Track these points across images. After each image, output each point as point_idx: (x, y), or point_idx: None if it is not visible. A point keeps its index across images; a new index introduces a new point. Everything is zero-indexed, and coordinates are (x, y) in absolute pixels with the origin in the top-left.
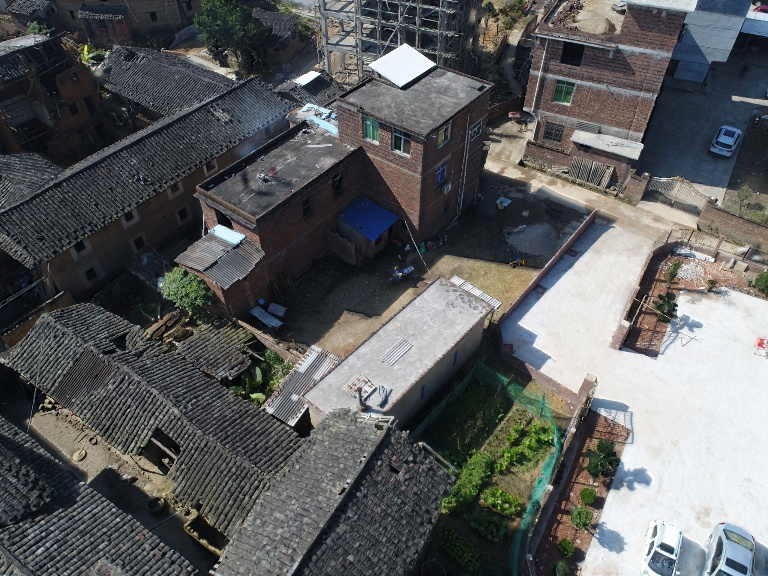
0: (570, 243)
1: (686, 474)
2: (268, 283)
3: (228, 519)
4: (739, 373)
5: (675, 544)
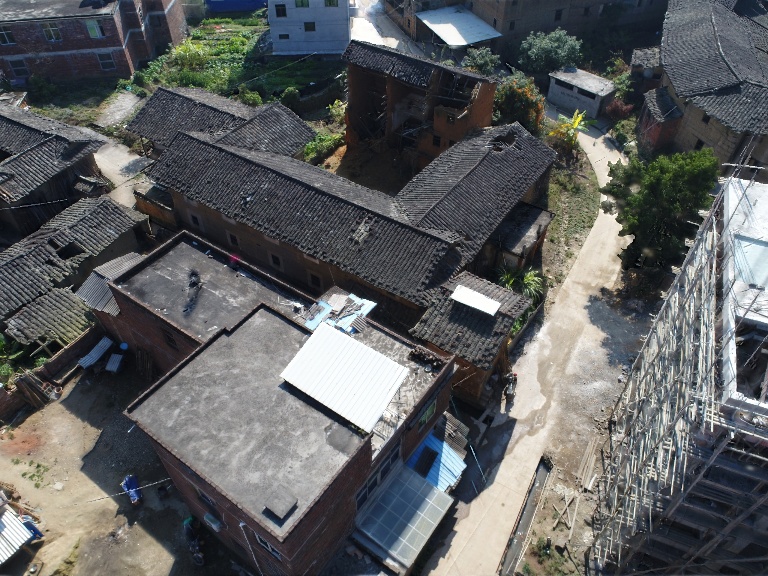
0: None
1: None
2: (136, 344)
3: None
4: None
5: None
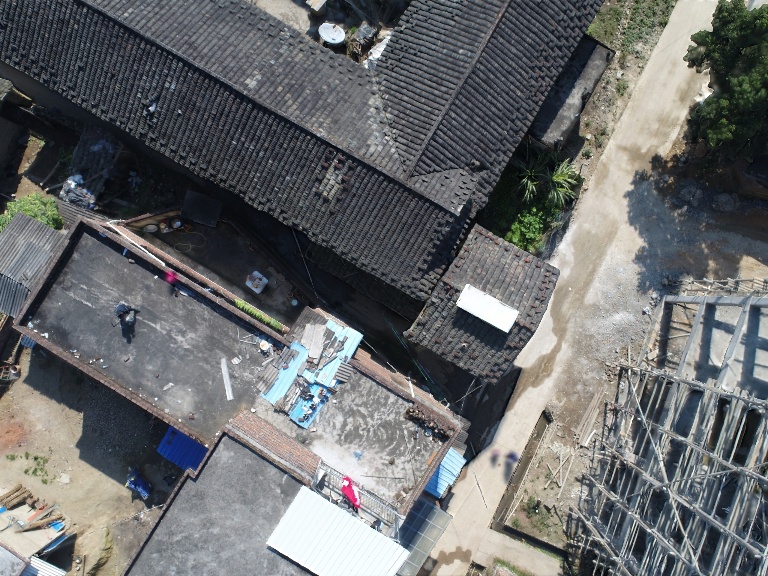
0: None
1: None
2: None
3: None
4: None
5: None
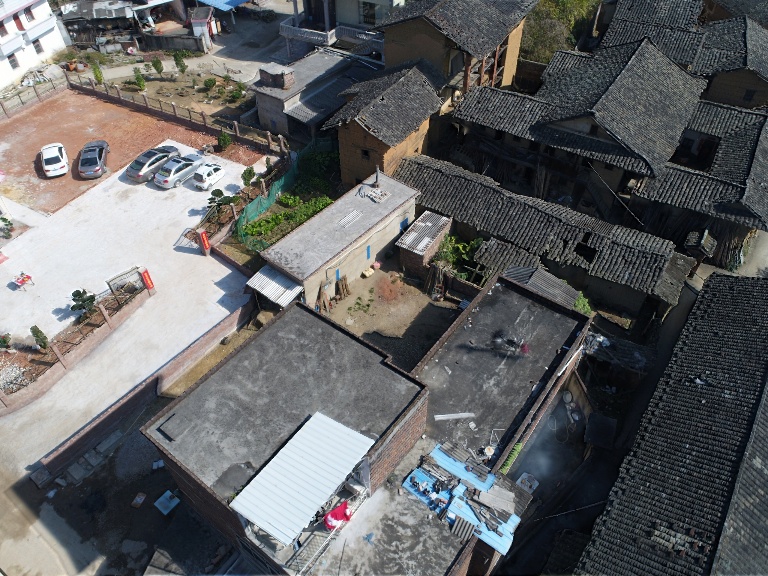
0: (117, 413)
1: (164, 213)
2: None
3: (452, 165)
4: (64, 271)
5: (203, 166)
